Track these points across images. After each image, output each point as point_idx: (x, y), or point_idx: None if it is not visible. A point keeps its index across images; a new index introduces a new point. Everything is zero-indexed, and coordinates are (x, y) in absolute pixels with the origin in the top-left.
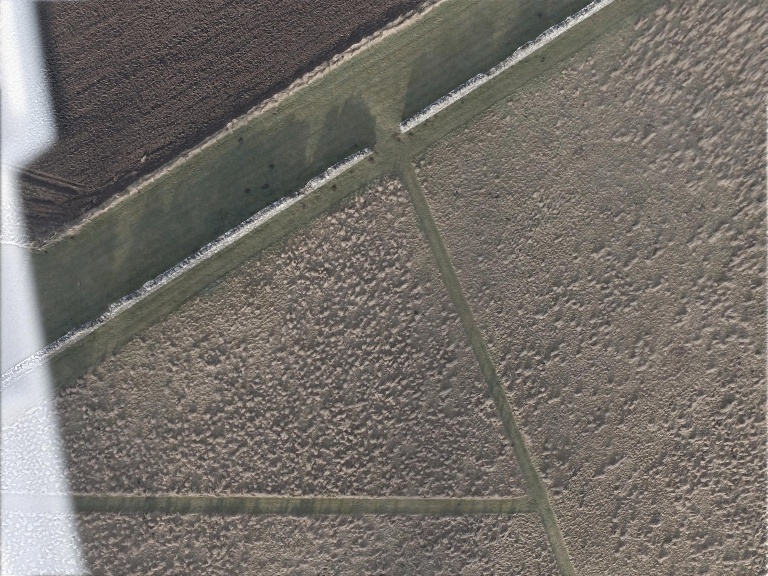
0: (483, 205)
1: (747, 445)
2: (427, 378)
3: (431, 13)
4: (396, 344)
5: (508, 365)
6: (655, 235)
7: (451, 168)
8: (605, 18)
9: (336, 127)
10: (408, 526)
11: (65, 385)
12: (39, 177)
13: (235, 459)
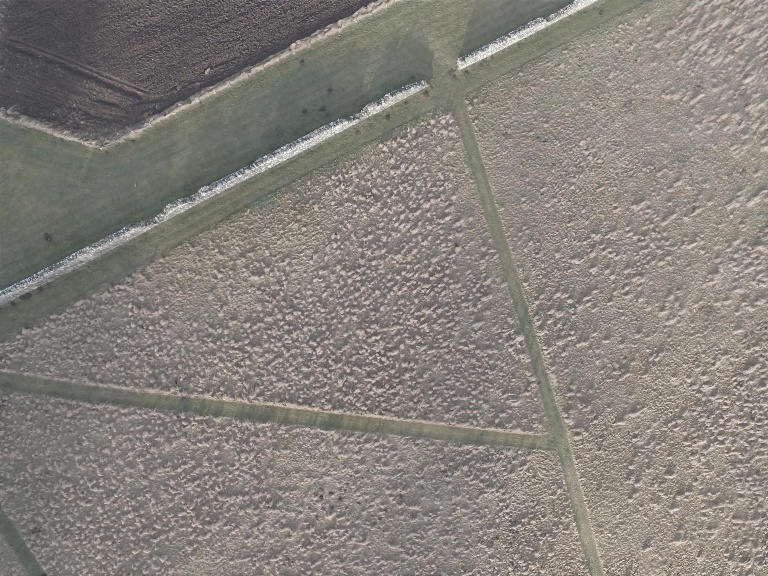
0: (530, 148)
1: (766, 409)
2: (462, 309)
3: None
4: (435, 273)
5: (541, 305)
6: (695, 194)
7: (502, 109)
8: None
9: (395, 58)
10: (431, 450)
11: (114, 282)
12: (106, 79)
13: (270, 369)
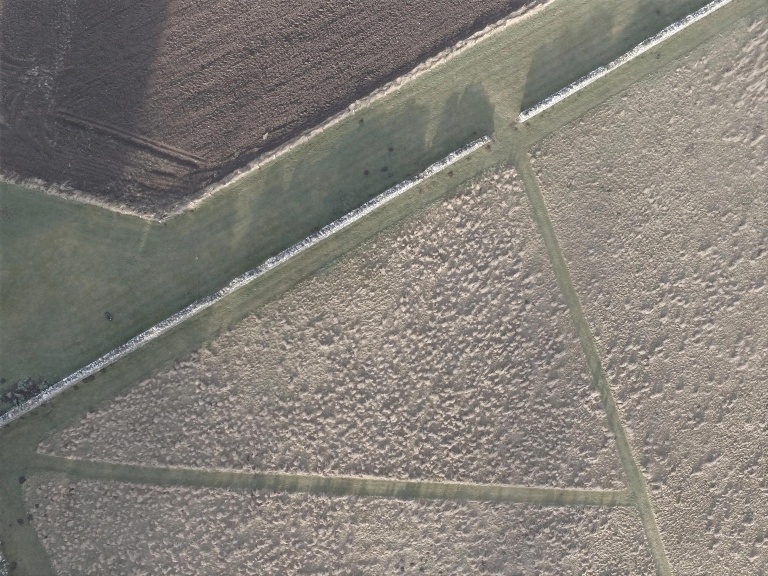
0: (595, 198)
1: None
2: (535, 368)
3: (553, 4)
4: (506, 332)
5: (613, 358)
6: (760, 236)
7: (566, 160)
8: (720, 18)
9: (456, 113)
10: (511, 514)
11: (179, 358)
12: (161, 149)
13: (344, 440)
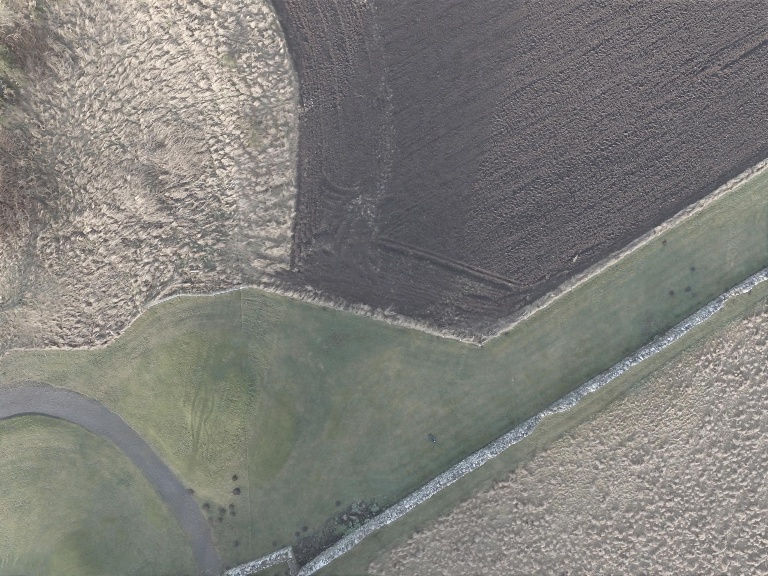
0: None
1: None
2: None
3: None
4: None
5: None
6: None
7: None
8: None
9: (755, 232)
10: None
11: (497, 478)
12: (477, 273)
13: (654, 558)
